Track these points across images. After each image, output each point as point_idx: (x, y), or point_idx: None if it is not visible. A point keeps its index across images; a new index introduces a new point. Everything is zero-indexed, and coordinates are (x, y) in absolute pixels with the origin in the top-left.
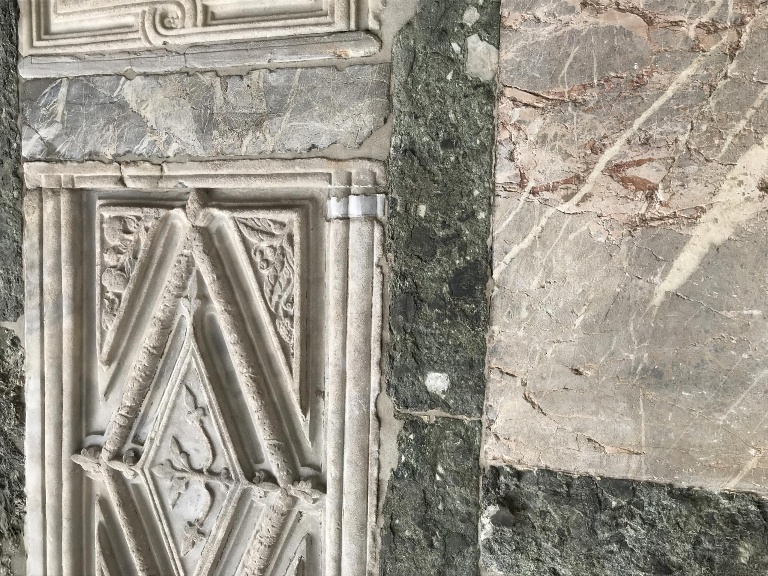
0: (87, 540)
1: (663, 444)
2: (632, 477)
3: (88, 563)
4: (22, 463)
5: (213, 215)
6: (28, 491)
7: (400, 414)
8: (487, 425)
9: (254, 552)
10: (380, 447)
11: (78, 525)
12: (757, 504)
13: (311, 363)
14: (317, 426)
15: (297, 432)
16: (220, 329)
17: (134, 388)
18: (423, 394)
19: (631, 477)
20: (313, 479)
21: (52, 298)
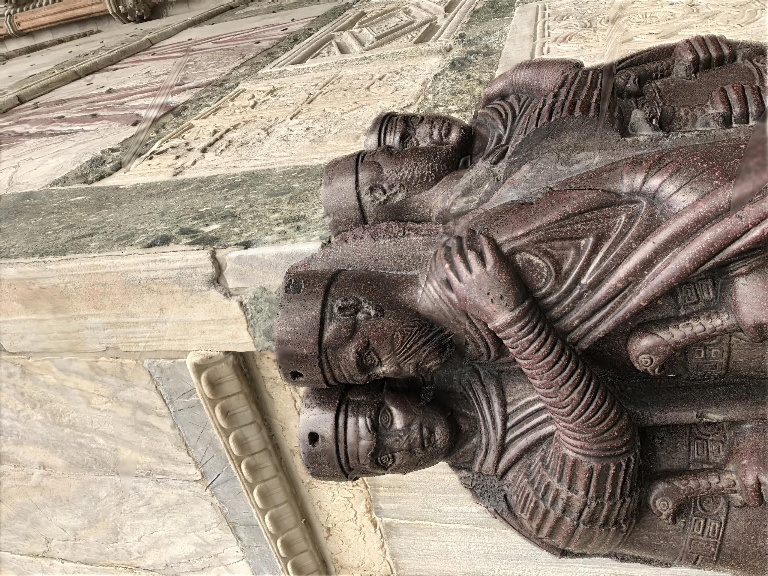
0: None
1: None
2: None
3: None
4: None
5: (420, 4)
6: None
7: None
8: None
9: None
10: None
11: None
12: None
13: (450, 9)
14: None
15: None
16: None
17: None
18: None
19: None
20: None
21: None
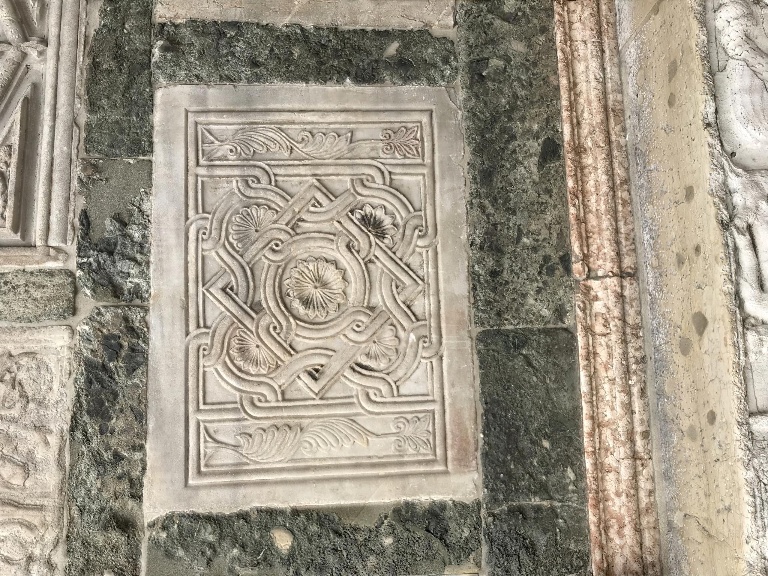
0: None
1: (253, 2)
2: (238, 20)
3: None
4: None
5: None
6: None
7: None
8: None
9: None
10: (87, 17)
11: None
12: (300, 30)
13: None
14: (42, 14)
15: (27, 19)
16: None
17: None
18: None
19: (237, 20)
20: (38, 41)
21: None
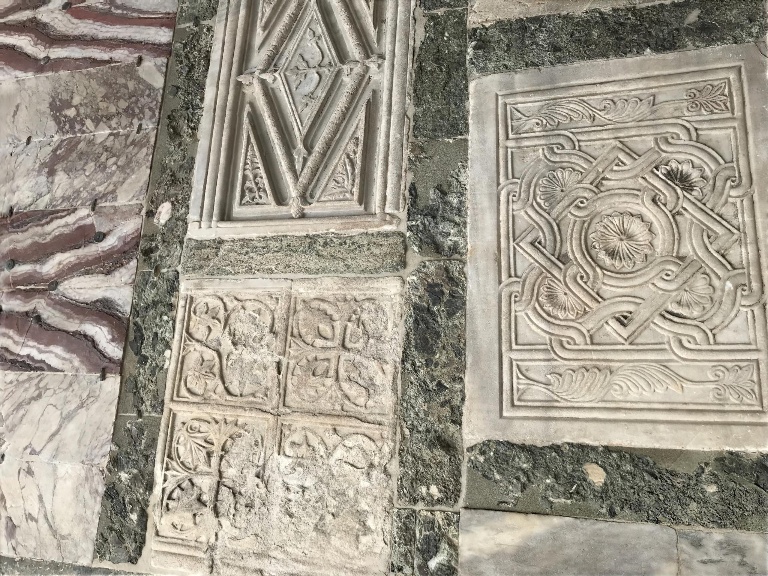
0: (238, 126)
1: None
2: (541, 14)
3: (237, 140)
4: (202, 93)
5: None
6: (205, 104)
7: (426, 14)
8: (470, 8)
9: (343, 98)
10: (415, 32)
11: (235, 115)
12: (599, 13)
13: (379, 7)
14: (381, 37)
15: (369, 42)
16: (330, 3)
17: (279, 36)
18: (438, 3)
19: (540, 14)
20: None
21: (235, 3)
